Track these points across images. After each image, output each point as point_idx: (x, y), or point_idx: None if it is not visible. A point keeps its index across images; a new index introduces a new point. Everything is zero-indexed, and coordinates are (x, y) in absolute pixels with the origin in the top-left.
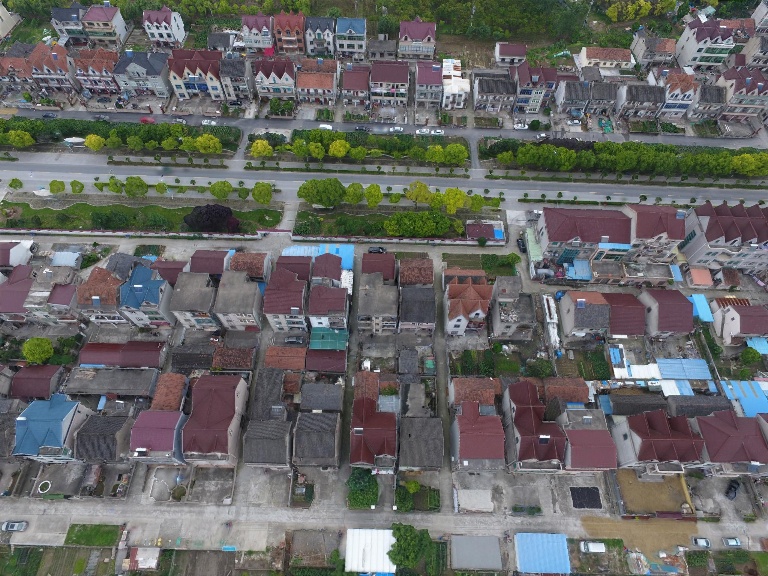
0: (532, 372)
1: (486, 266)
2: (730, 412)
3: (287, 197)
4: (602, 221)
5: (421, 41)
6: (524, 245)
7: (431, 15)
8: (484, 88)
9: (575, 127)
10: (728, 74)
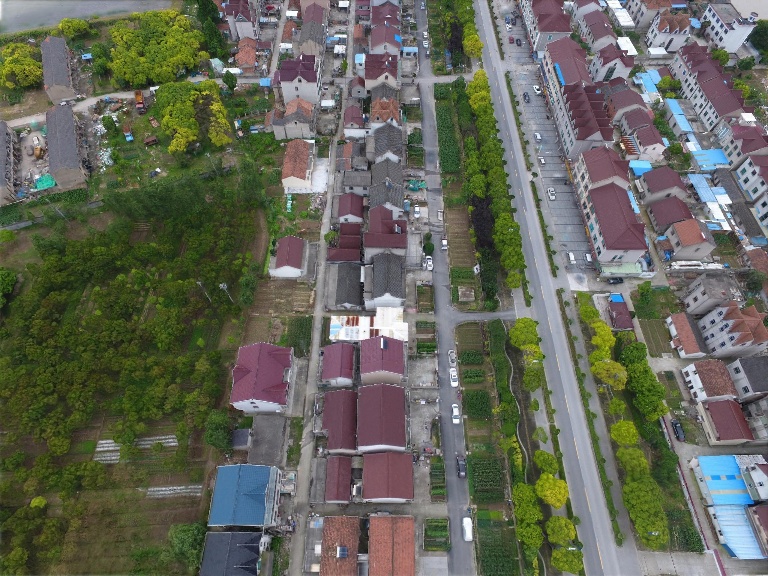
0: (760, 286)
1: (653, 315)
2: (762, 166)
3: (635, 574)
4: (621, 204)
5: (289, 369)
6: (615, 279)
7: (186, 357)
8: (397, 290)
9: (421, 212)
10: (370, 75)
